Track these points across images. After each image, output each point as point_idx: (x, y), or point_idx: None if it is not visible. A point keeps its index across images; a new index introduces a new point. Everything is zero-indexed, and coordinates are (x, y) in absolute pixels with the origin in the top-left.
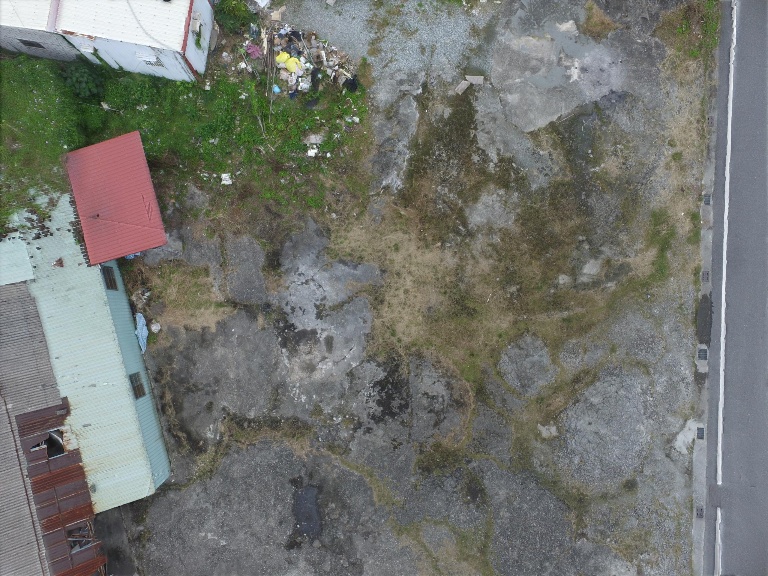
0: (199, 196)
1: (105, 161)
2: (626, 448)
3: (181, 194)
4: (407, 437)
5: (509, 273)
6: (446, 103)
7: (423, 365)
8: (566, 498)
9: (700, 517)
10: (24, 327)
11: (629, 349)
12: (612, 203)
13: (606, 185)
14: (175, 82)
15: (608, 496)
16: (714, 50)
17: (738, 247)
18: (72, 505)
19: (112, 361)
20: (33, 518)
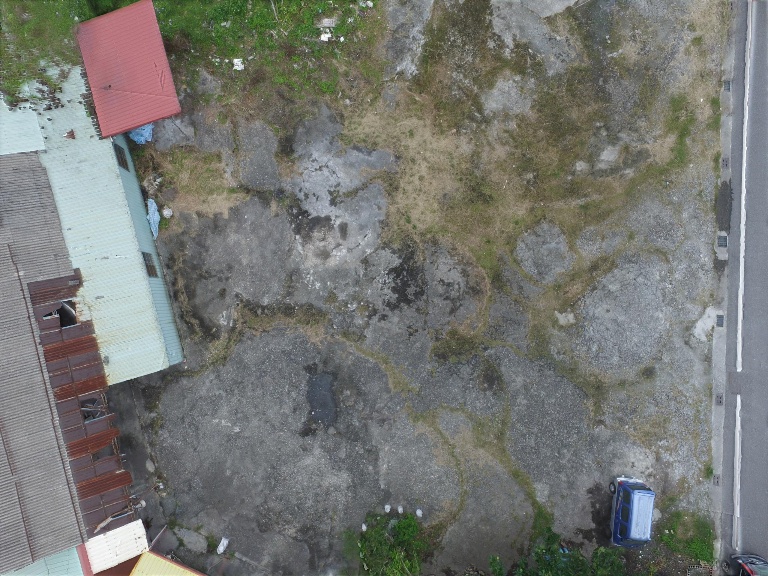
0: (211, 81)
1: (117, 30)
2: (645, 335)
3: (193, 79)
4: (423, 324)
5: (526, 160)
6: None
7: (439, 252)
8: (584, 385)
9: (720, 404)
10: (35, 196)
11: (647, 236)
12: (630, 89)
13: (624, 71)
14: None
15: (626, 383)
16: None
17: (758, 133)
18: (85, 375)
19: (125, 234)
20: (46, 385)
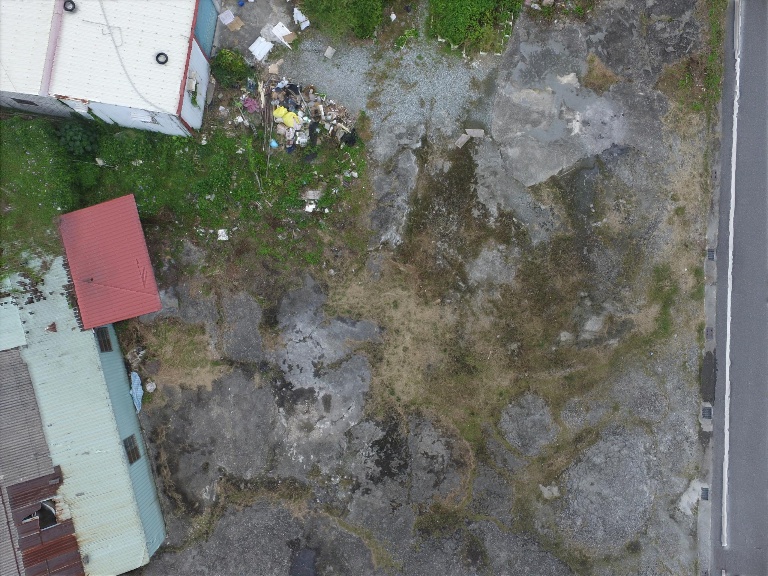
0: (195, 252)
1: (99, 224)
2: (629, 509)
3: (177, 250)
4: (406, 498)
5: (510, 330)
6: (446, 157)
7: (423, 424)
8: (568, 560)
9: None
10: (16, 395)
11: (632, 407)
12: (614, 258)
13: (608, 240)
14: (171, 137)
15: (611, 558)
16: (717, 102)
17: (742, 303)
18: None
19: (106, 428)
20: None
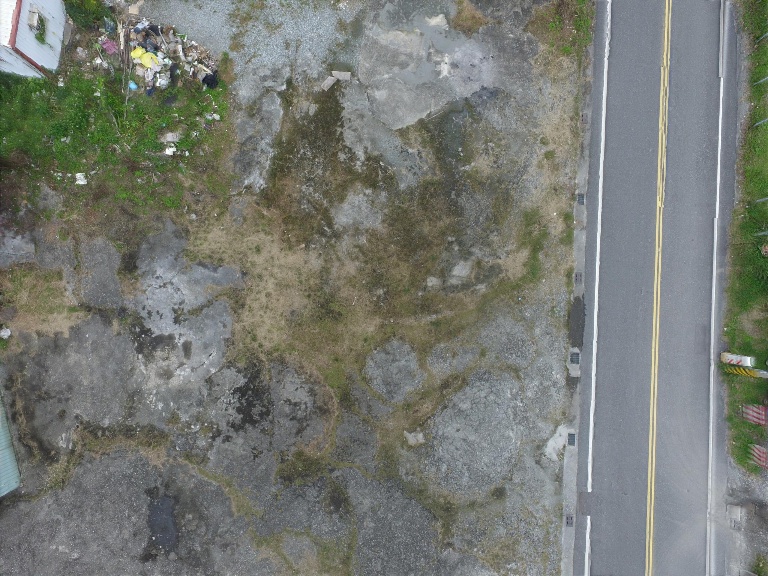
0: (52, 196)
1: None
2: (494, 455)
3: (33, 194)
4: (268, 445)
5: (375, 275)
6: (311, 100)
7: (285, 371)
8: (432, 507)
9: (570, 526)
10: None
11: (499, 353)
12: (482, 203)
13: (476, 184)
14: (26, 78)
15: (476, 505)
16: (589, 45)
17: (612, 248)
18: None
19: None
20: None
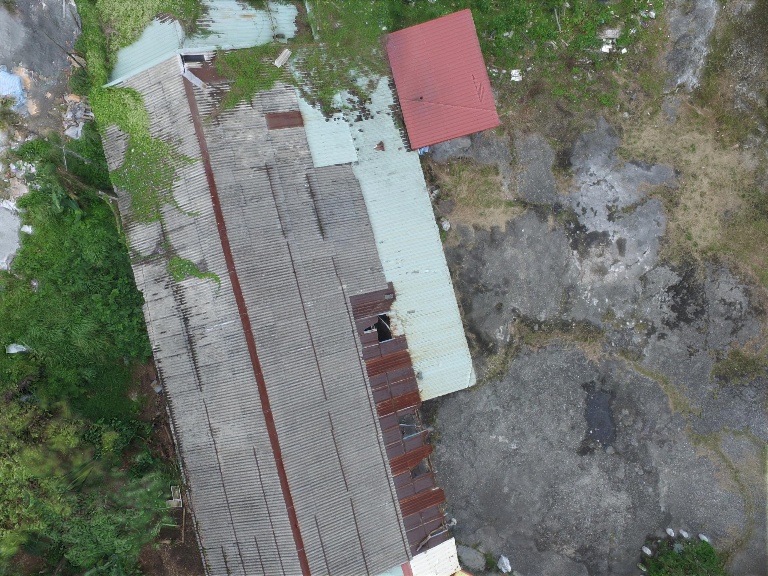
0: None
1: (431, 41)
2: None
3: None
4: (703, 344)
5: None
6: None
7: (720, 270)
8: None
9: None
10: (352, 209)
11: None
12: None
13: None
14: None
15: None
16: None
17: None
18: (402, 391)
19: (433, 248)
20: (370, 400)
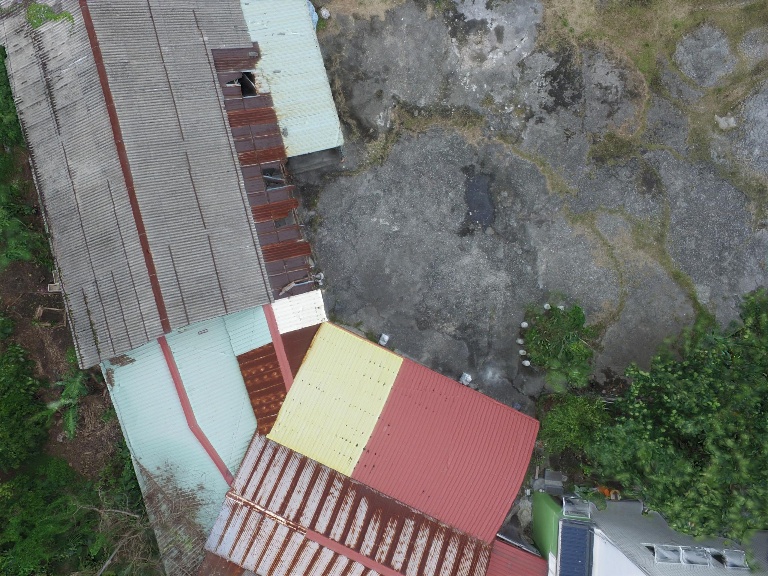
0: None
1: None
2: None
3: None
4: (580, 127)
5: None
6: None
7: (596, 56)
8: (744, 189)
9: None
10: None
11: None
12: None
13: None
14: None
15: None
16: None
17: None
18: (266, 145)
19: (300, 12)
20: (232, 149)
